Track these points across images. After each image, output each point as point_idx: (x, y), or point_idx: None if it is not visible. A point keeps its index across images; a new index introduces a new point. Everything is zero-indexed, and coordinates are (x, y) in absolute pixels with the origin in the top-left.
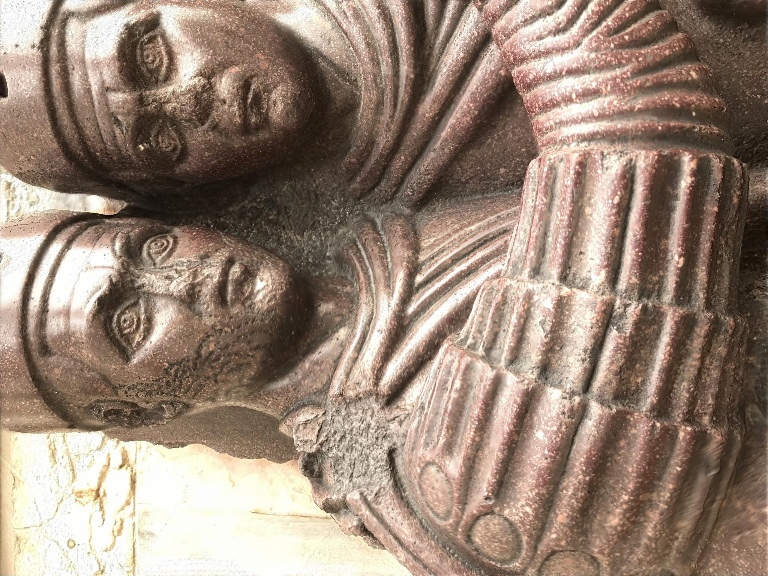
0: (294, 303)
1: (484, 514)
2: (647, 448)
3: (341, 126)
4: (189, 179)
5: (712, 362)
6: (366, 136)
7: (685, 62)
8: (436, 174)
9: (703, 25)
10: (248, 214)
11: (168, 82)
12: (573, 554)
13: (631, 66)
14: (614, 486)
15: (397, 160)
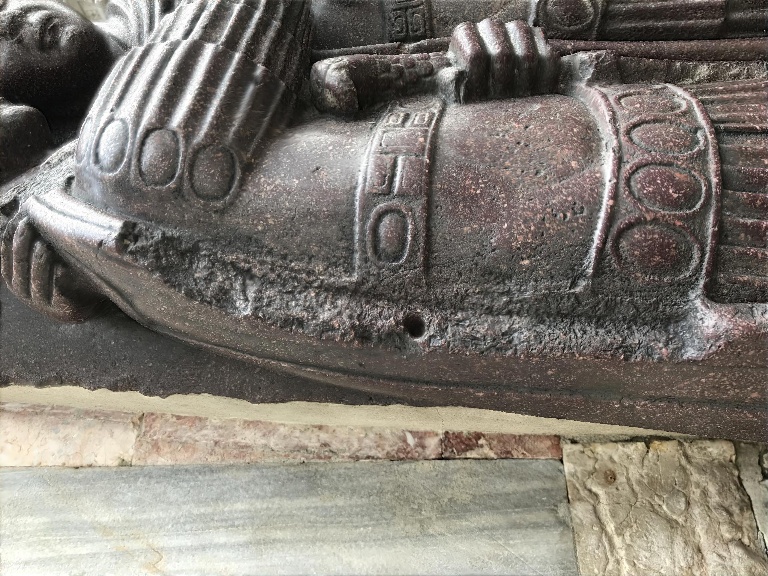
0: (36, 125)
1: (108, 124)
2: (213, 56)
3: None
4: None
5: (266, 39)
6: None
7: None
8: None
9: (324, 2)
10: None
11: None
12: (161, 132)
13: None
14: (192, 84)
15: None
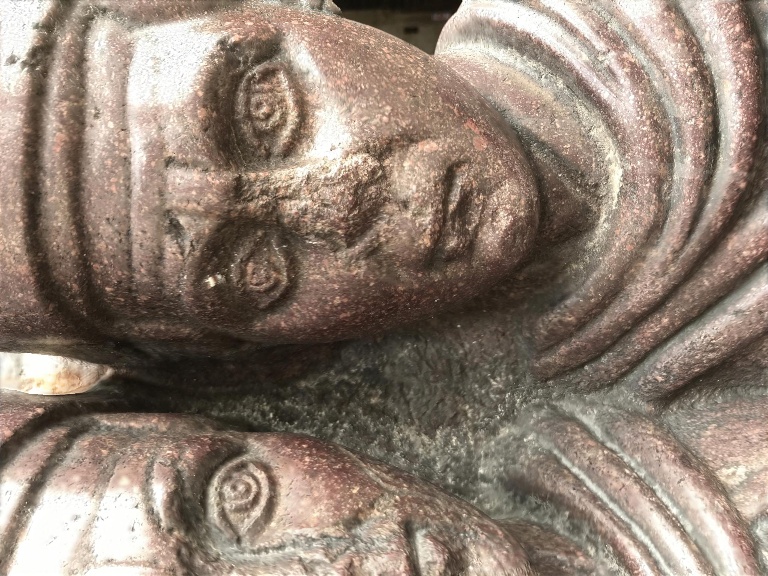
0: None
1: None
2: None
3: (548, 260)
4: (267, 339)
5: None
6: (609, 281)
7: None
8: (728, 352)
9: None
10: (335, 394)
11: (292, 159)
12: None
13: None
14: None
15: (651, 323)
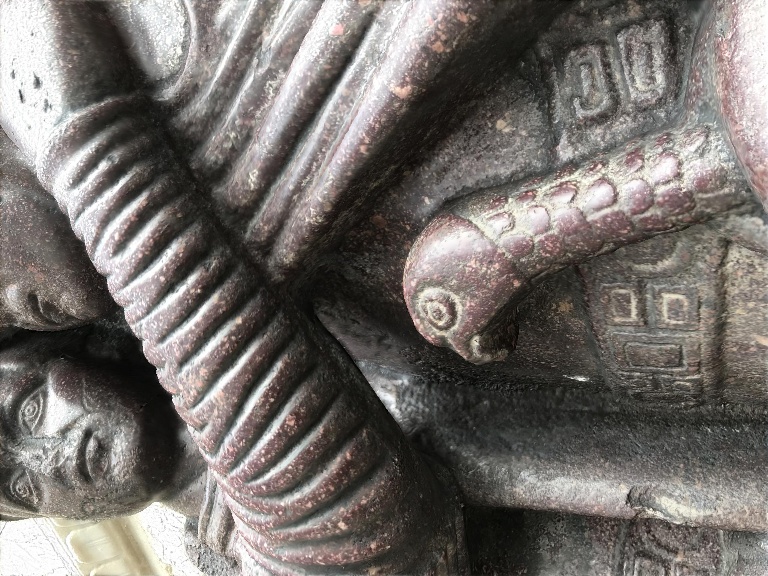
0: (151, 467)
1: None
2: None
3: None
4: None
5: None
6: None
7: (339, 502)
8: None
9: None
10: None
11: None
12: None
13: (272, 518)
14: None
15: None
